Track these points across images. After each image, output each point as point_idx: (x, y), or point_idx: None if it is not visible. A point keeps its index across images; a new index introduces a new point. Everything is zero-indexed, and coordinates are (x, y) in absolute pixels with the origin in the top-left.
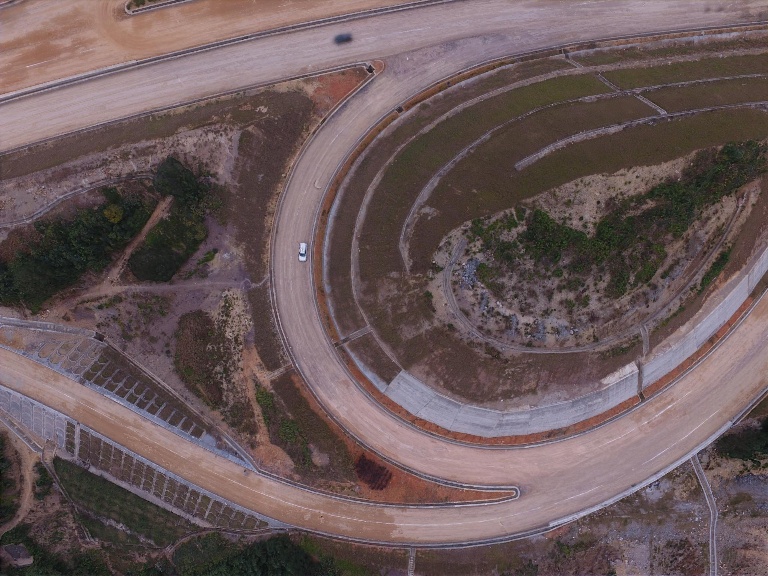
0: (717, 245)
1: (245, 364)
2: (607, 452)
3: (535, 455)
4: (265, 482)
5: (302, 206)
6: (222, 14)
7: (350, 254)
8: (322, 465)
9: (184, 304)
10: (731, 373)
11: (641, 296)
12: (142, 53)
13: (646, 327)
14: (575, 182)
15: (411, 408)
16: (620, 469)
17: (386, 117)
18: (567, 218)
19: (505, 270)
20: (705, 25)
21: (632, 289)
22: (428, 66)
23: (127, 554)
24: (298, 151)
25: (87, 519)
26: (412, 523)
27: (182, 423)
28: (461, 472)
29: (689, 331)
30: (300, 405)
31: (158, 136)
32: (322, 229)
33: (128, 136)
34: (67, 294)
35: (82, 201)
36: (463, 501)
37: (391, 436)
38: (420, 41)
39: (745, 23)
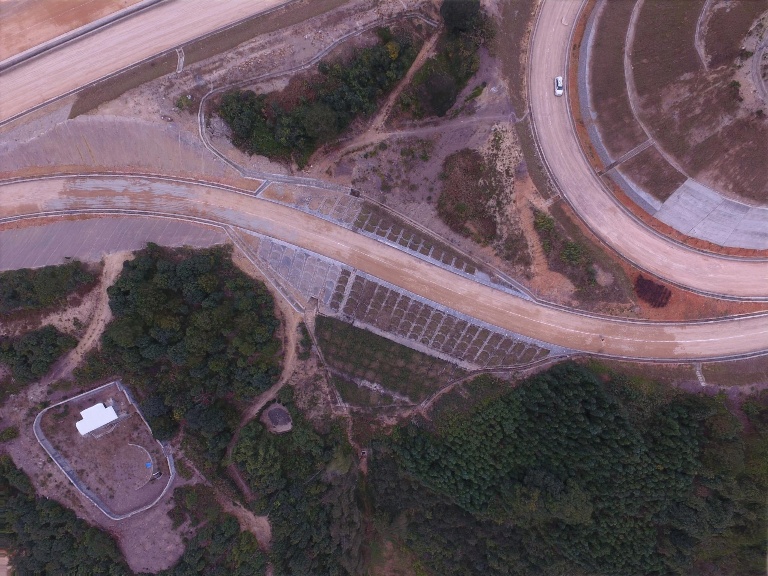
0: None
1: (517, 196)
2: None
3: None
4: (543, 311)
5: (552, 43)
6: None
7: (623, 72)
8: (606, 285)
9: (449, 145)
10: None
11: None
12: None
13: None
14: None
15: (684, 226)
16: None
17: None
18: None
19: None
20: None
21: None
22: None
23: (375, 418)
24: None
25: (343, 380)
26: (693, 339)
27: (454, 262)
28: (737, 286)
29: None
30: (576, 230)
31: None
32: (575, 63)
33: None
34: (331, 147)
35: (358, 43)
36: (743, 313)
37: (663, 257)
38: None
39: None
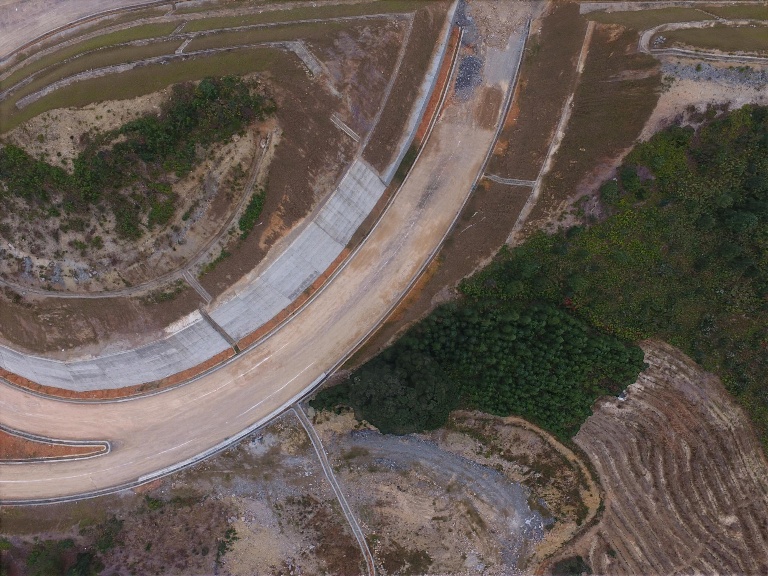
0: (249, 188)
1: None
2: (202, 405)
3: (129, 409)
4: None
5: None
6: None
7: None
8: None
9: None
10: (328, 325)
11: (165, 238)
12: None
13: (189, 272)
14: (42, 116)
15: None
16: (214, 422)
17: None
18: (44, 154)
19: (5, 210)
20: None
21: (152, 231)
22: (38, 17)
23: None
24: None
25: None
26: (1, 479)
27: None
28: (53, 427)
29: (254, 279)
30: None
31: None
32: None
33: None
34: None
35: None
36: (52, 456)
37: None
38: None
39: None
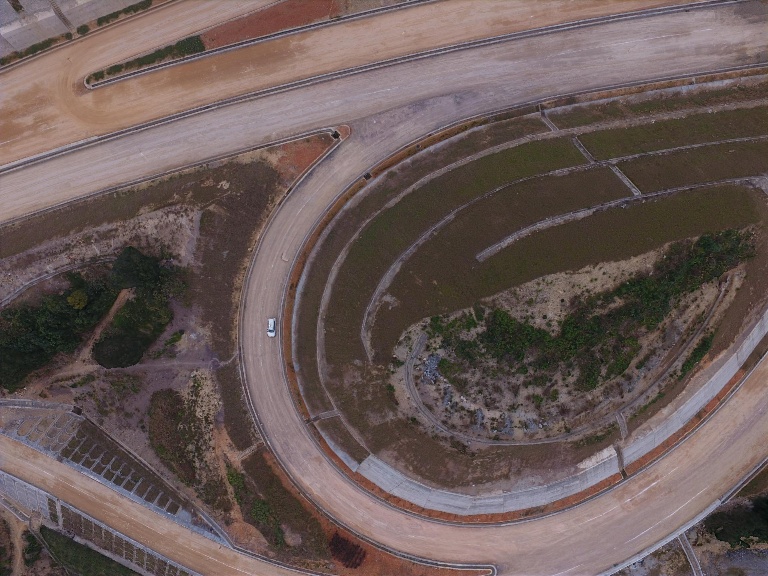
0: (698, 330)
1: (216, 443)
2: (587, 530)
3: (512, 533)
4: (240, 558)
5: (270, 280)
6: (182, 84)
7: (316, 335)
8: (295, 545)
9: (155, 382)
10: (720, 449)
11: (615, 387)
12: (104, 128)
13: (622, 414)
14: (536, 281)
15: (384, 486)
16: (601, 548)
17: (353, 185)
18: (529, 317)
19: (467, 366)
20: (696, 70)
21: (605, 381)
22: (396, 129)
23: None
24: (264, 224)
25: None
26: None
27: (158, 499)
28: (436, 550)
29: (671, 413)
30: (272, 484)
31: (120, 218)
32: (290, 303)
33: (91, 217)
34: (42, 373)
35: (48, 287)
36: None
37: (365, 513)
38: (388, 102)
39: (741, 66)
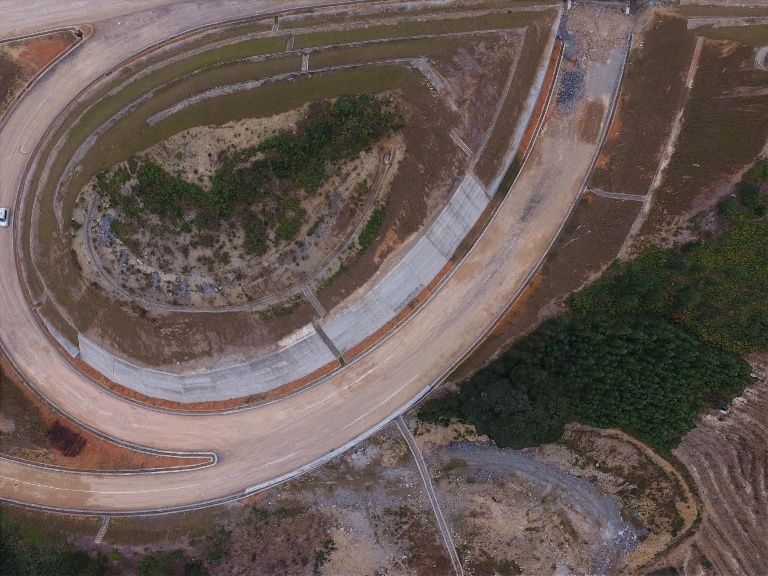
0: (370, 203)
1: None
2: (307, 417)
3: (235, 421)
4: None
5: (6, 171)
6: None
7: (31, 216)
8: (8, 431)
9: None
10: (432, 337)
11: (289, 254)
12: None
13: (308, 287)
14: (182, 134)
15: (106, 374)
16: (319, 434)
17: (95, 82)
18: (181, 171)
19: (137, 226)
20: None
21: (277, 246)
22: (140, 31)
23: None
24: (2, 115)
25: None
26: (108, 490)
27: None
28: (159, 438)
29: (366, 292)
30: None
31: None
32: None
33: None
34: None
35: None
36: (160, 468)
37: (90, 403)
38: (133, 6)
39: None
